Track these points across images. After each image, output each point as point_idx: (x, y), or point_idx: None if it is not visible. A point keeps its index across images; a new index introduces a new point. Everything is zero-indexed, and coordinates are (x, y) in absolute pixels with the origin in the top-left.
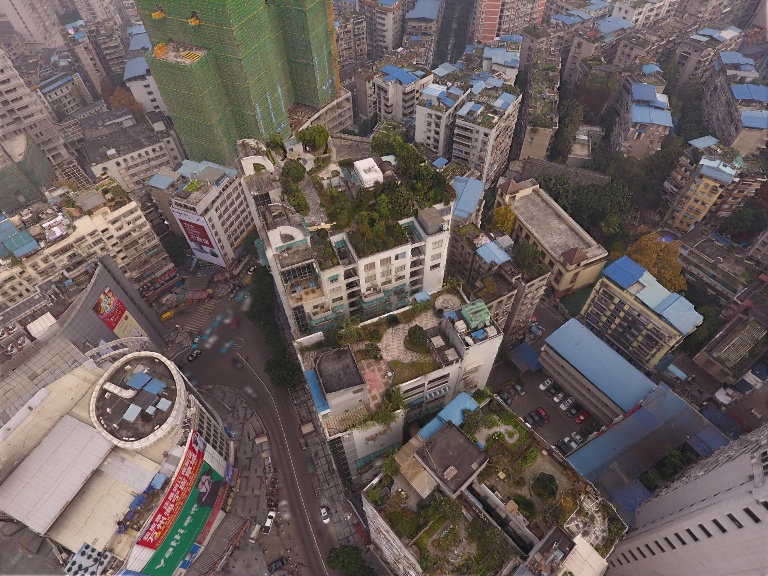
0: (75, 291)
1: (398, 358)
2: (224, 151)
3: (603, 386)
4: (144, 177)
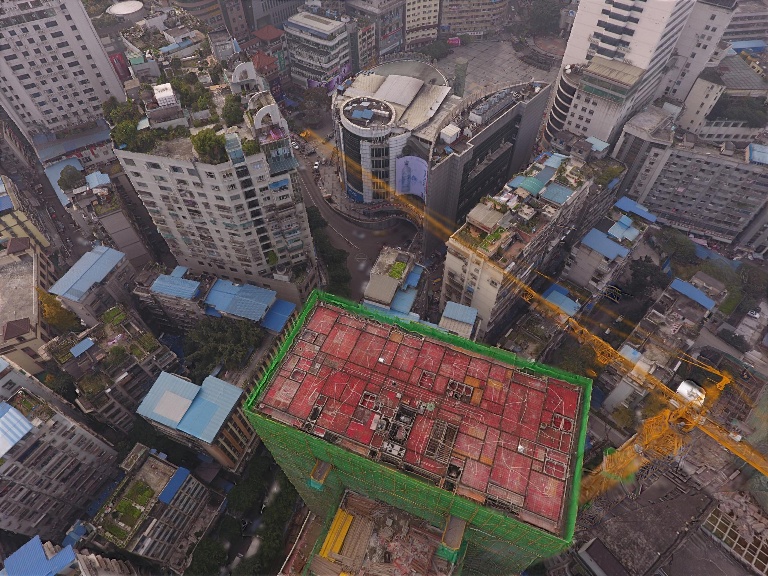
0: None
1: (192, 69)
2: None
3: (80, 168)
4: None
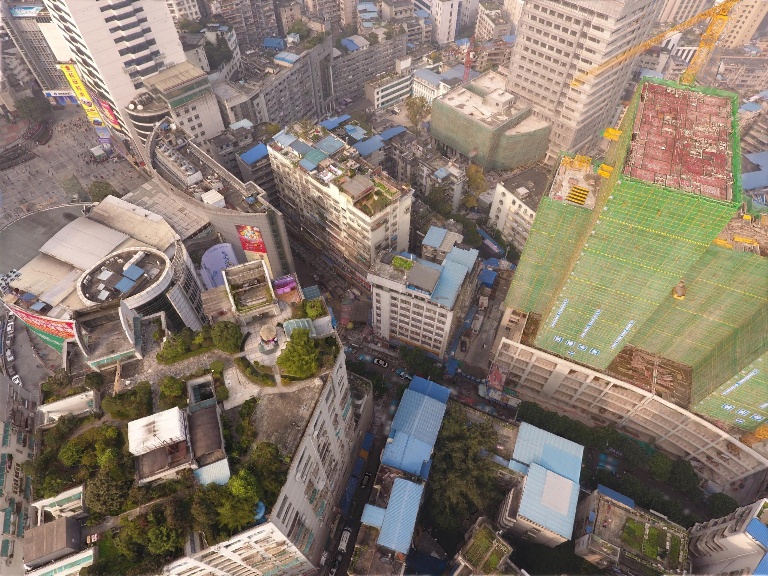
0: (243, 207)
1: None
2: (516, 288)
3: None
4: (520, 231)
